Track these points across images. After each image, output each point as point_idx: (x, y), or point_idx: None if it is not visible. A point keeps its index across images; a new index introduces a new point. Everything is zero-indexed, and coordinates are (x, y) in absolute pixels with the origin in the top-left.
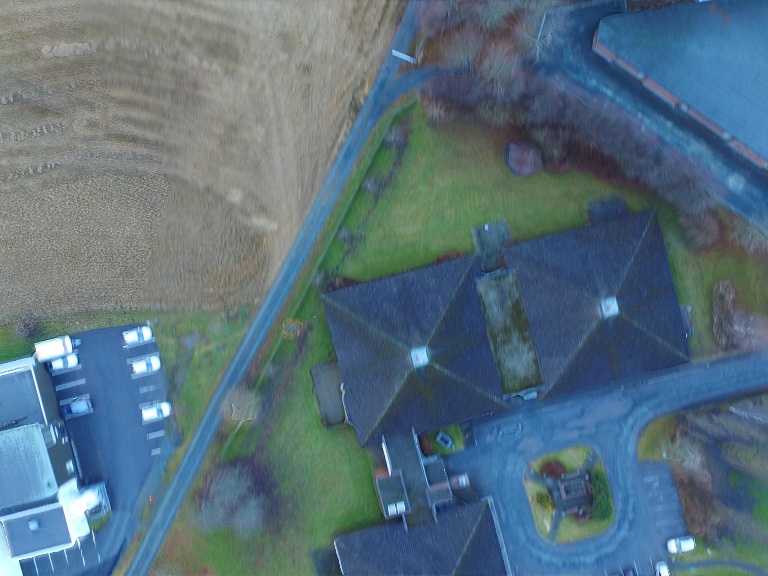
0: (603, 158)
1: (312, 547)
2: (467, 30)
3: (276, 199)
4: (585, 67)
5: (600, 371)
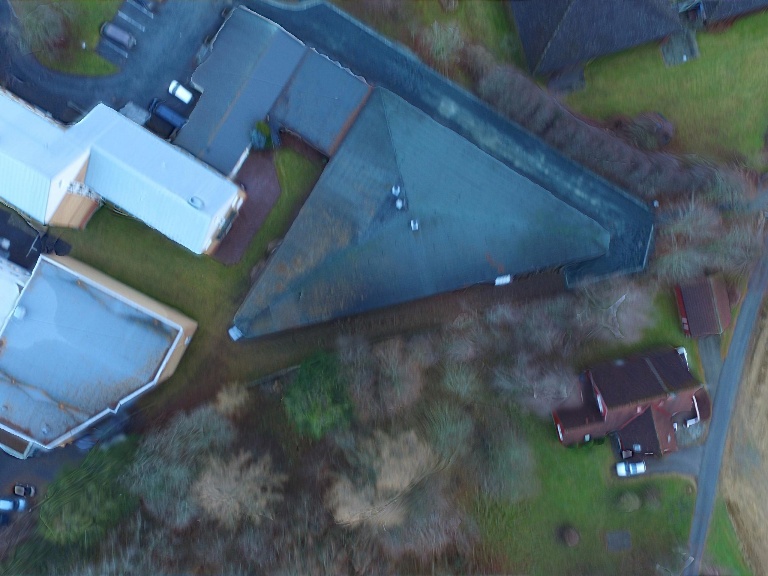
0: None
1: None
2: None
3: None
4: (604, 216)
5: None
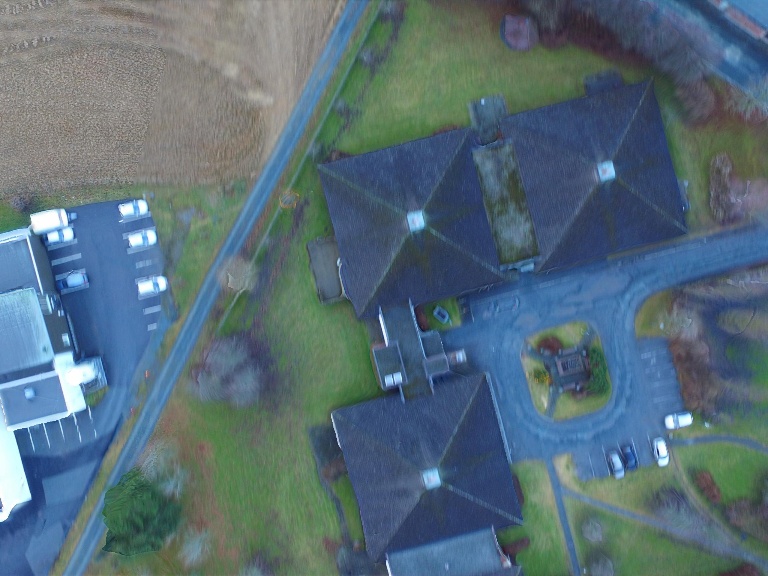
0: (599, 28)
1: (309, 424)
2: None
3: (272, 73)
4: None
5: (597, 241)
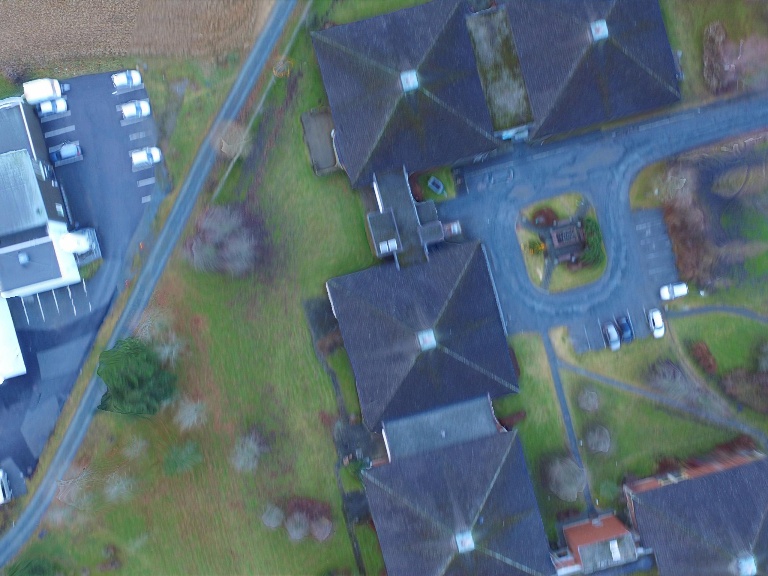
0: None
1: (304, 297)
2: None
3: None
4: None
5: (591, 106)
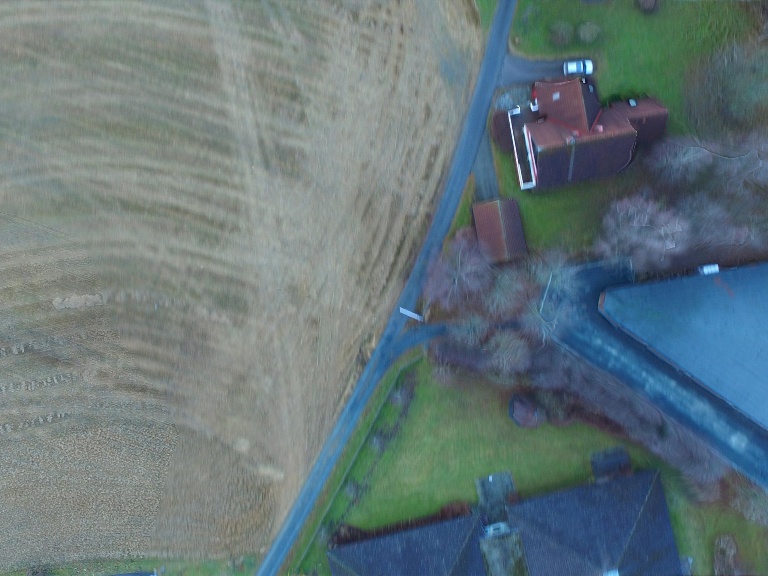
0: (607, 419)
1: None
2: (474, 303)
3: (283, 449)
4: (590, 327)
5: None
